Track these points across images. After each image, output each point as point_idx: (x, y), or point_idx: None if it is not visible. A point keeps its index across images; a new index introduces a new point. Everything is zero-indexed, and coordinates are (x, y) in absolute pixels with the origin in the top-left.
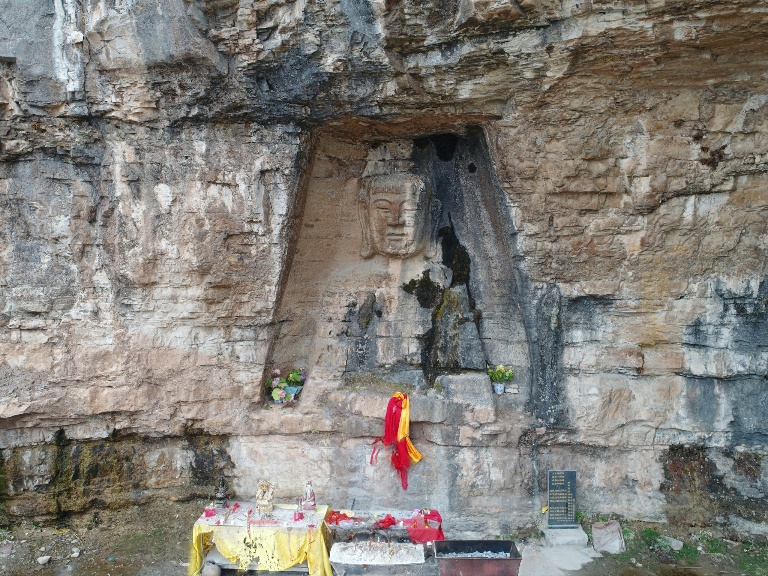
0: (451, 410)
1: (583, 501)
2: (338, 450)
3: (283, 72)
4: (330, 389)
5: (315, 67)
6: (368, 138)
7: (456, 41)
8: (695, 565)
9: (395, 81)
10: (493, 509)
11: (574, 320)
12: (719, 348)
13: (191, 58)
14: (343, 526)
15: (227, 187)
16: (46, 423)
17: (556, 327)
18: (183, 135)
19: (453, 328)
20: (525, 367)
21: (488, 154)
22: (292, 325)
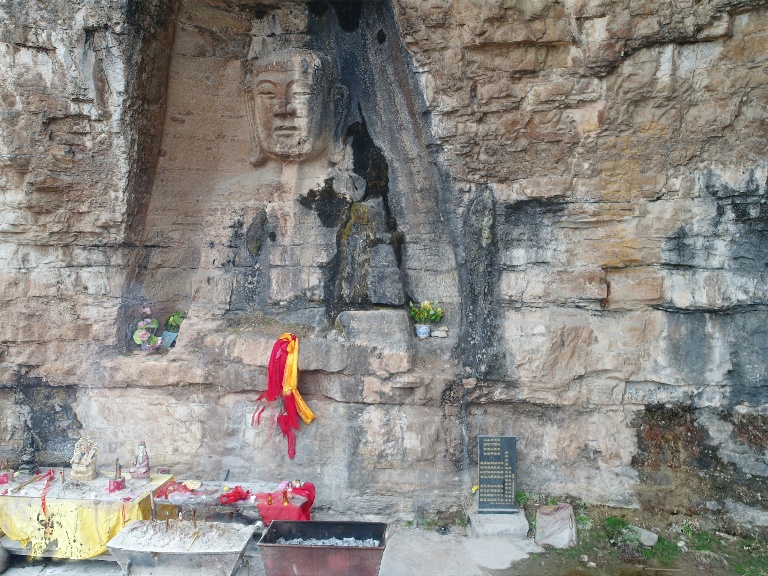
0: (352, 355)
1: (528, 478)
2: (213, 408)
3: None
4: (206, 330)
5: None
6: None
7: None
8: (672, 566)
9: None
10: (406, 486)
11: (515, 236)
12: (711, 269)
13: None
14: (172, 500)
15: (44, 53)
16: None
17: (489, 244)
18: None
19: (362, 252)
20: (457, 303)
21: (390, 4)
22: (168, 253)
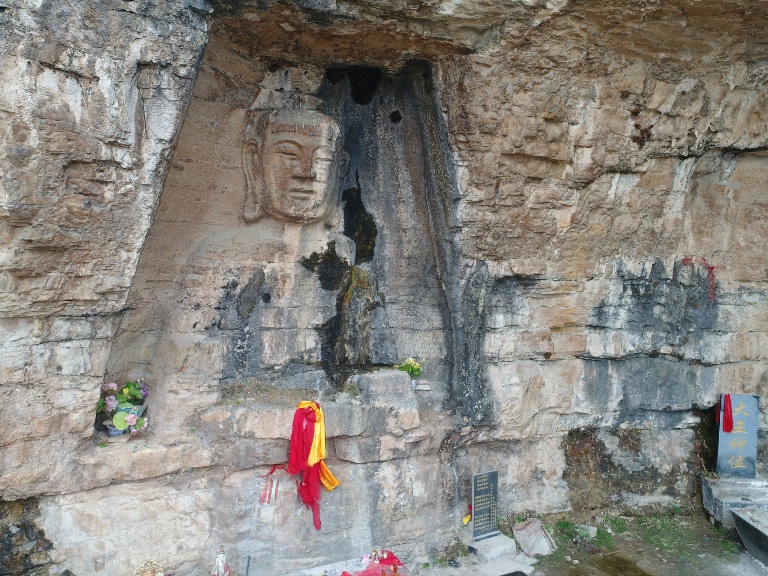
0: (372, 417)
1: (498, 503)
2: (219, 491)
3: None
4: (205, 405)
5: None
6: (273, 53)
7: None
8: (615, 549)
9: None
10: (418, 532)
11: (494, 303)
12: (616, 329)
13: None
14: None
15: (73, 79)
16: None
17: (482, 311)
18: None
19: (363, 315)
20: (435, 359)
21: (433, 99)
22: (134, 315)
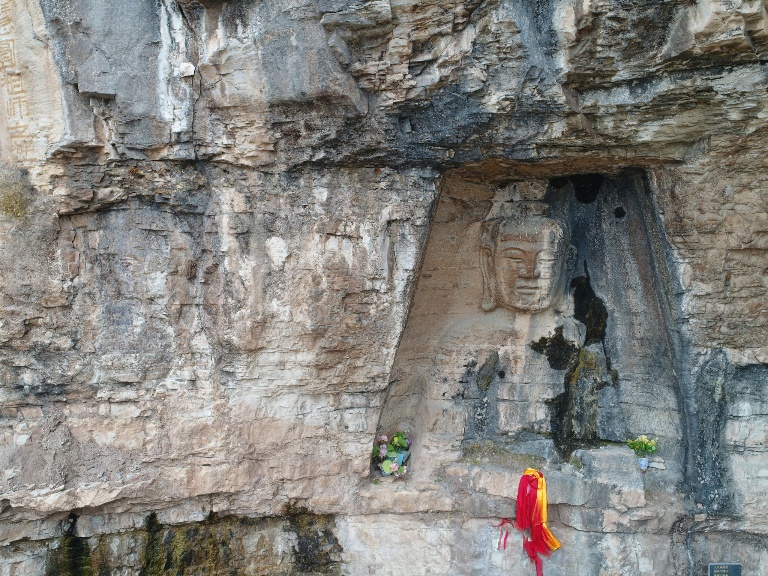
0: (594, 491)
1: None
2: (459, 532)
3: (432, 111)
4: (448, 461)
5: (474, 106)
6: (500, 178)
7: (652, 76)
8: None
9: (565, 122)
10: None
11: (739, 389)
12: None
13: (327, 96)
14: None
15: (347, 239)
16: (137, 508)
17: (720, 398)
18: (302, 181)
19: (590, 393)
20: (672, 438)
21: (651, 200)
22: (400, 385)
